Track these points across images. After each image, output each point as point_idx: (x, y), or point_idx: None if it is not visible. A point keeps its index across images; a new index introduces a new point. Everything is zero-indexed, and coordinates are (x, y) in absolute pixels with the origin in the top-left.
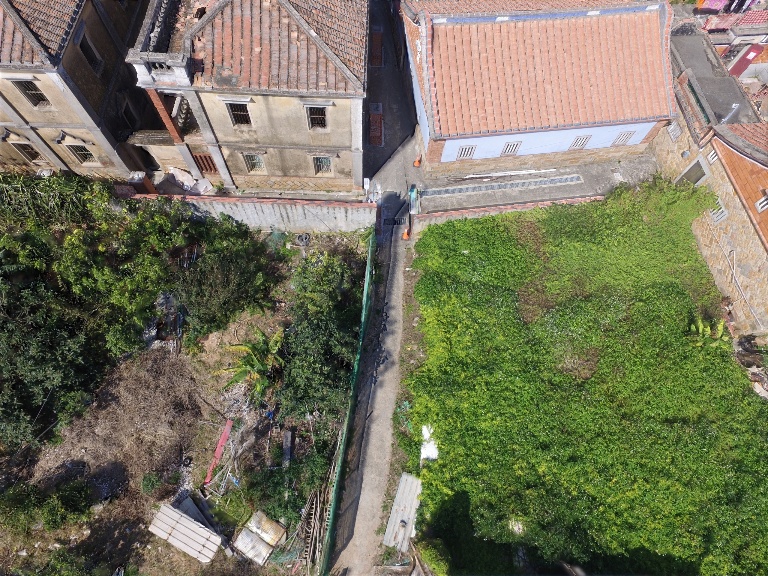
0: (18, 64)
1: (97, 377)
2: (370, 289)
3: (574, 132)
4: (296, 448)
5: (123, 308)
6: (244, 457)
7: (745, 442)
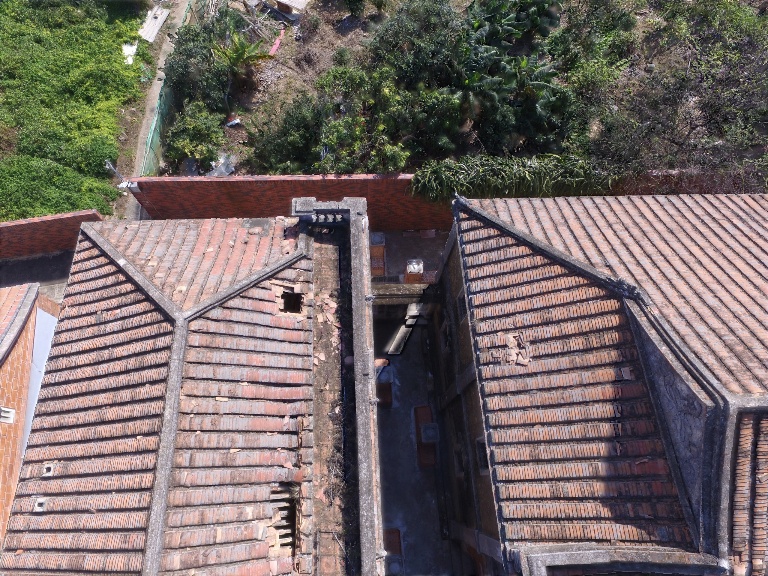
0: None
1: None
2: None
3: None
4: None
5: None
6: None
7: None
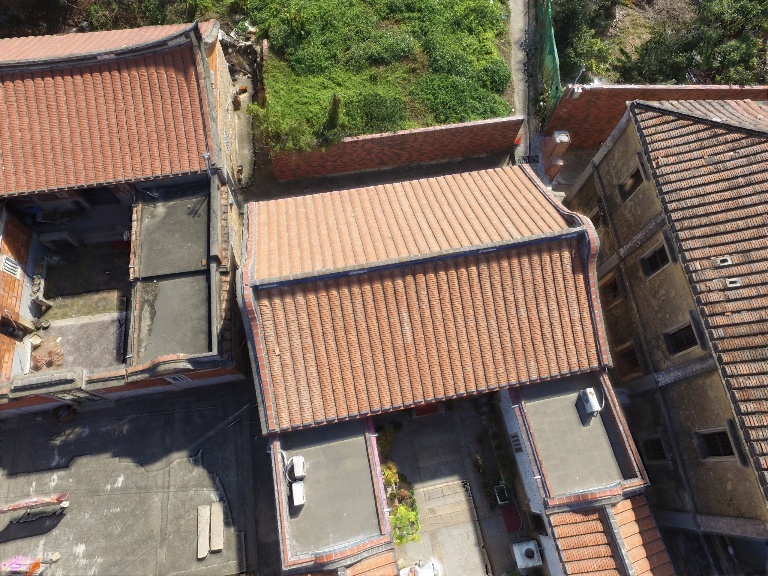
0: None
1: None
2: None
3: None
4: None
5: None
6: None
7: None
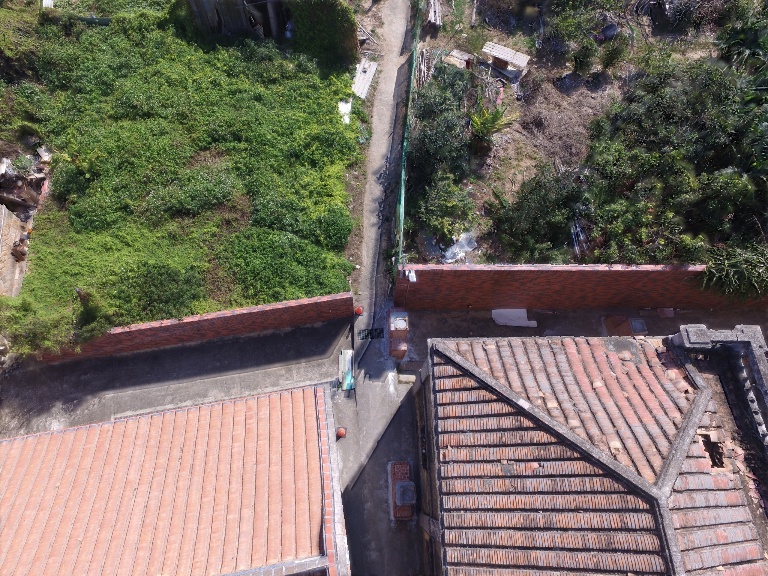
0: None
1: None
2: None
3: None
4: None
5: None
6: None
7: None
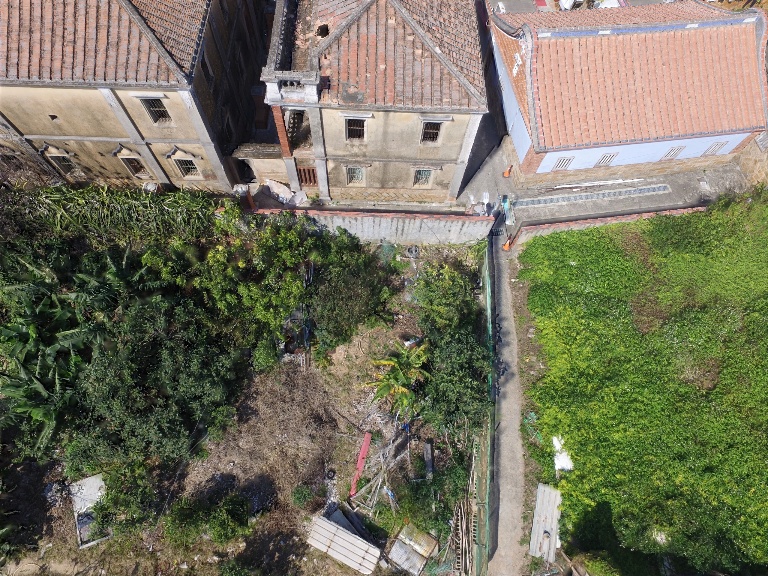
0: (154, 83)
1: (238, 391)
2: None
3: (671, 143)
4: (435, 460)
5: (268, 324)
6: (392, 470)
7: None
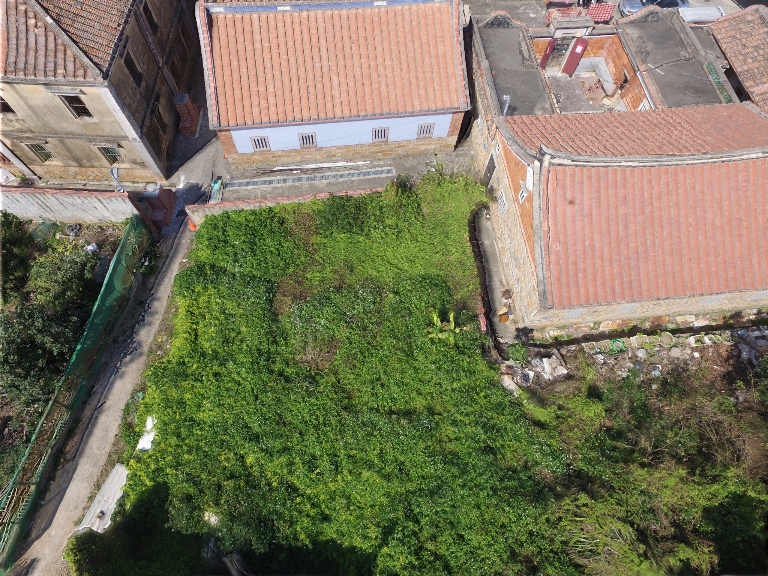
0: None
1: None
2: (131, 280)
3: (366, 124)
4: (5, 438)
5: None
6: None
7: (466, 434)
